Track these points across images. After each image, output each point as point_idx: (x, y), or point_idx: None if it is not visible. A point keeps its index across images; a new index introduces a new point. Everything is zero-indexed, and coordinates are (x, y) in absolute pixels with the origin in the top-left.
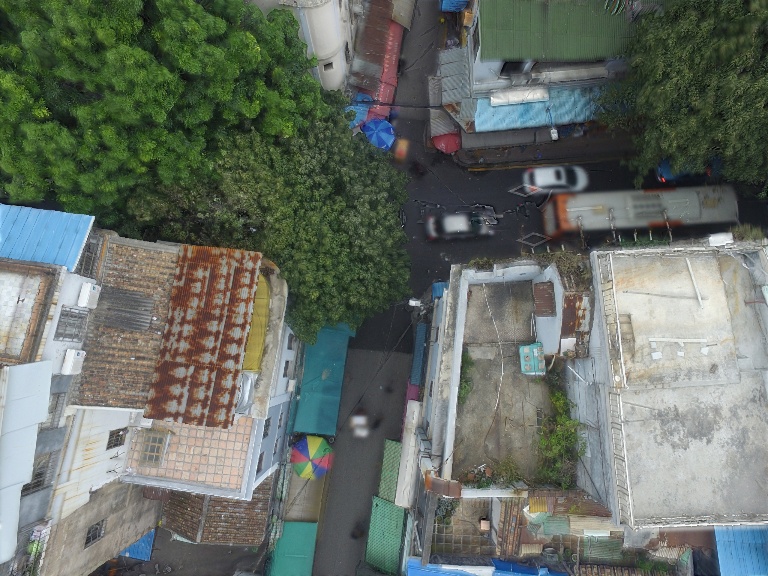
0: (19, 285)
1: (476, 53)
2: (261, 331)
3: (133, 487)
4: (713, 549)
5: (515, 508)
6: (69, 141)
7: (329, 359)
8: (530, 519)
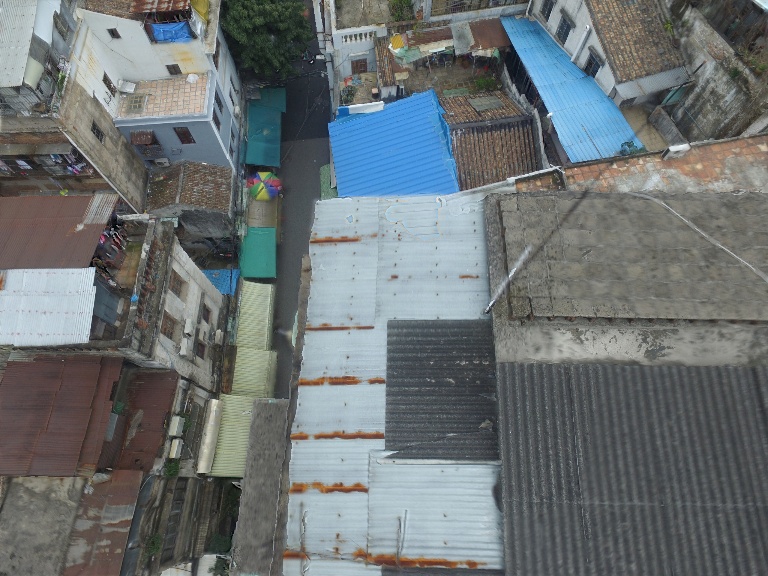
0: None
1: None
2: (204, 4)
3: (123, 144)
4: (510, 45)
5: (384, 50)
6: None
7: (268, 124)
8: (395, 55)
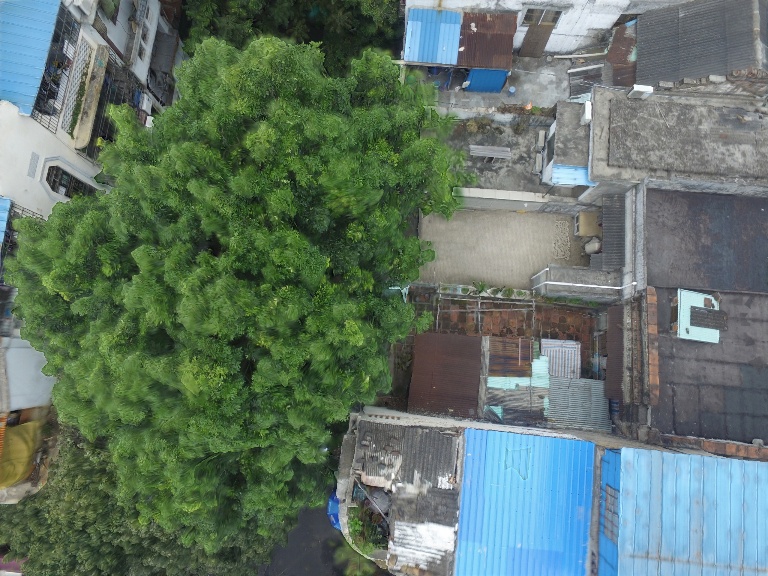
0: None
1: None
2: None
3: None
4: None
5: None
6: (28, 330)
7: None
8: None
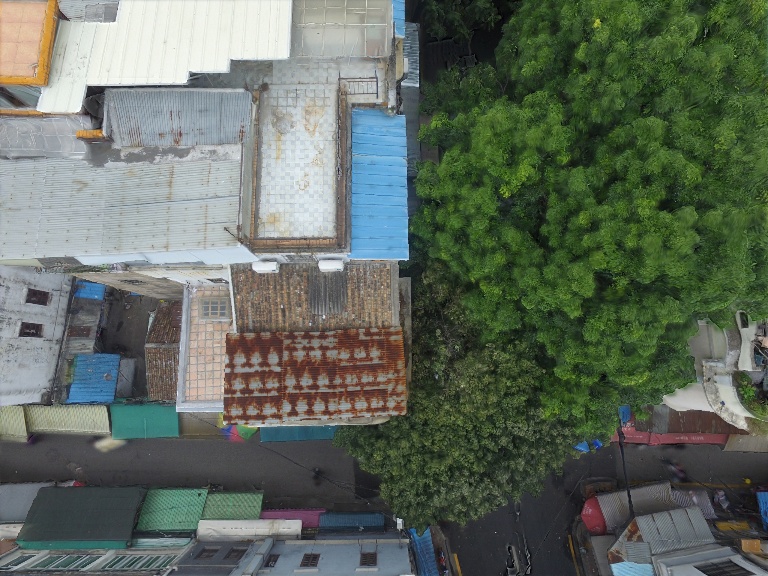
0: (325, 218)
1: (707, 572)
2: None
3: None
4: None
5: None
6: (479, 226)
7: None
8: None
